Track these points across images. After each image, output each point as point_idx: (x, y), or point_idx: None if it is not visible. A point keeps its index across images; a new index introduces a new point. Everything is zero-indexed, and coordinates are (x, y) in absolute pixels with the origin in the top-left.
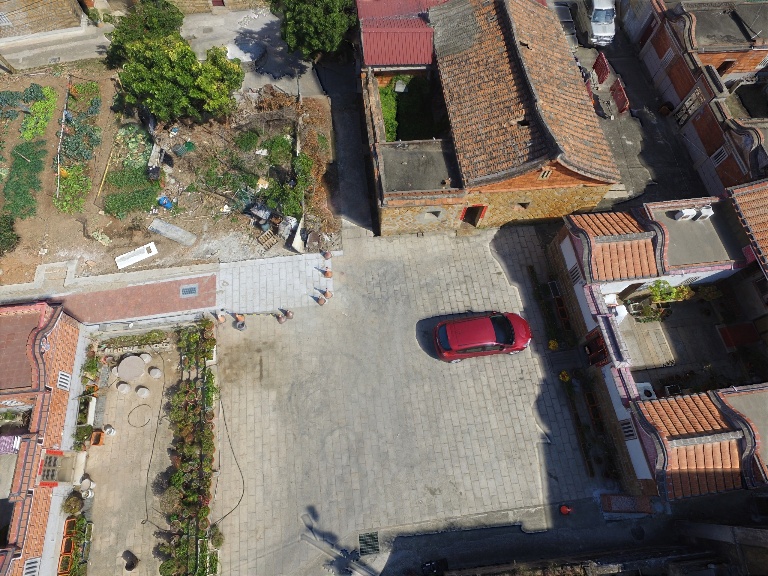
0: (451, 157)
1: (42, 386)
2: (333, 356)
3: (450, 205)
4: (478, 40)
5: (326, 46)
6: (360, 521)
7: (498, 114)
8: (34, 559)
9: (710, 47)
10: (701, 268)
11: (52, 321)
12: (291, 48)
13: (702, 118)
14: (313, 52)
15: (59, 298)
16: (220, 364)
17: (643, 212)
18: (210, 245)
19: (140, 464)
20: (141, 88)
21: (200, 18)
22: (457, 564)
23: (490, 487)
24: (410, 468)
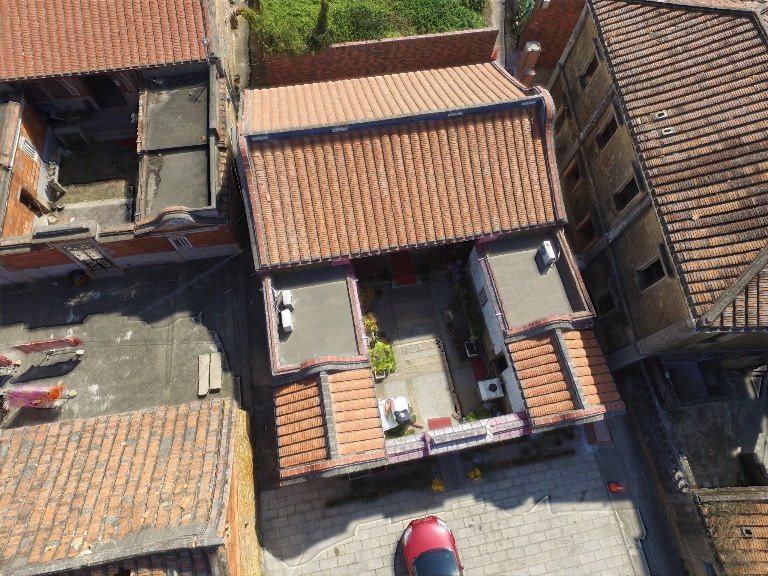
0: None
1: None
2: None
3: None
4: None
5: None
6: None
7: None
8: None
9: None
10: (358, 316)
11: None
12: None
13: (115, 250)
14: None
15: None
16: None
17: (282, 374)
18: None
19: None
20: None
21: None
22: None
23: None
24: None
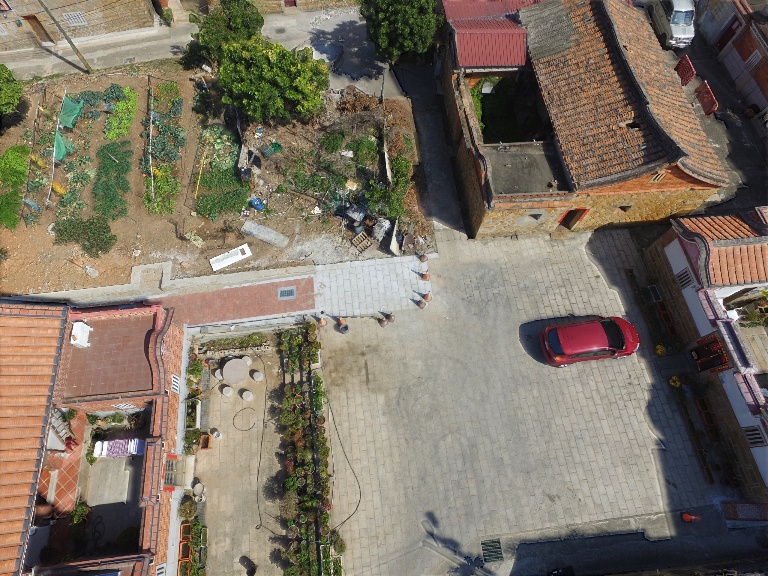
0: (554, 159)
1: (162, 389)
2: (438, 360)
3: (554, 208)
4: (575, 42)
5: (418, 47)
6: (481, 527)
7: (605, 116)
8: (162, 564)
9: None
10: None
11: (167, 323)
12: (380, 49)
13: None
14: None
15: (155, 300)
16: (325, 367)
17: (754, 216)
18: (303, 247)
19: (249, 468)
20: (240, 89)
21: (272, 18)
22: (583, 572)
23: (609, 494)
24: (526, 474)
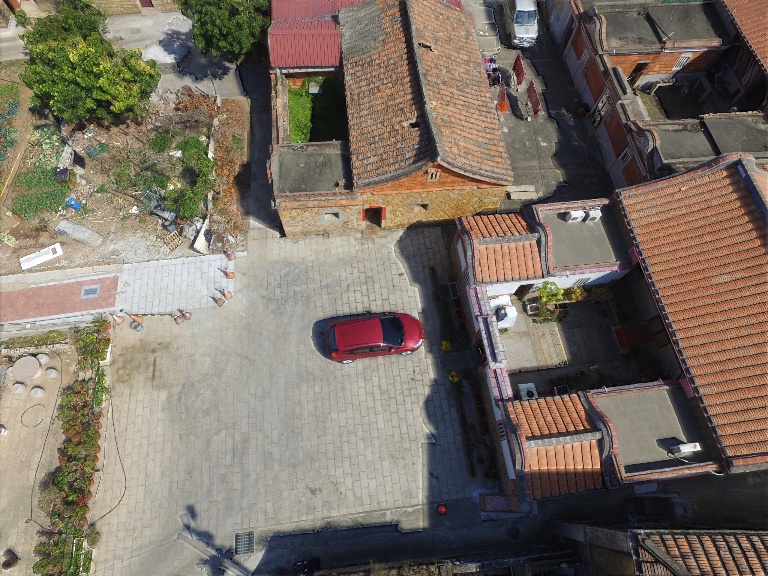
0: (349, 159)
1: None
2: (227, 357)
3: (346, 206)
4: (382, 42)
5: (234, 48)
6: (238, 520)
7: (392, 116)
8: None
9: (621, 49)
10: (586, 269)
11: None
12: (203, 50)
13: (611, 120)
14: (235, 53)
15: None
16: (114, 364)
17: (533, 214)
18: (116, 246)
19: (29, 464)
20: (42, 90)
21: (129, 19)
22: (330, 563)
23: (371, 487)
24: (293, 468)
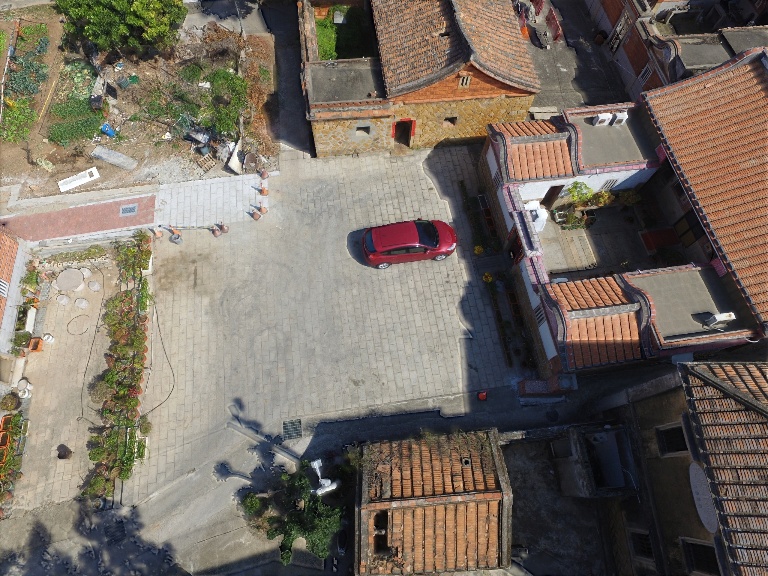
0: (379, 73)
1: None
2: (265, 265)
3: (378, 119)
4: None
5: None
6: (285, 410)
7: (421, 28)
8: None
9: None
10: (615, 167)
11: None
12: None
13: (630, 40)
14: None
15: (3, 220)
16: (156, 274)
17: (561, 118)
18: (151, 169)
19: (77, 368)
20: (77, 14)
21: None
22: None
23: (412, 378)
24: (335, 362)
